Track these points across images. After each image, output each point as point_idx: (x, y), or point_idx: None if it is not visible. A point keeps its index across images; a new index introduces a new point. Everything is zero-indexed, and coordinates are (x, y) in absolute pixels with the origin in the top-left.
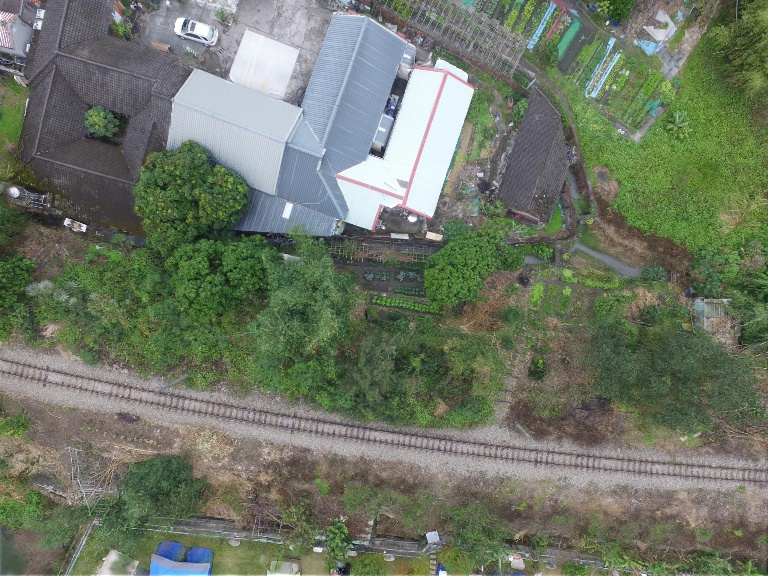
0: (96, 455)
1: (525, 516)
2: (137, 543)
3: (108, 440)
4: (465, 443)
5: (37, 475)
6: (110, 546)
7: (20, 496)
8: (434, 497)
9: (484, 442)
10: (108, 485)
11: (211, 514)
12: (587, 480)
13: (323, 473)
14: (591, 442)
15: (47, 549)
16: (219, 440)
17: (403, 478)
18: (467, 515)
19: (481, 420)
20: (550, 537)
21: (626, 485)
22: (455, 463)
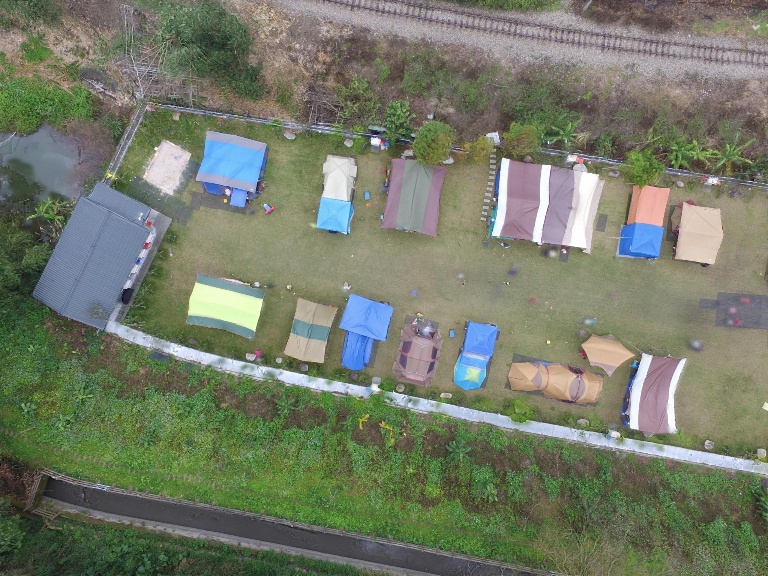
0: (150, 33)
1: (590, 107)
2: (190, 134)
3: (163, 11)
4: (530, 25)
5: (87, 69)
6: (162, 136)
7: (70, 85)
8: (497, 85)
9: (550, 25)
10: (162, 63)
11: (265, 116)
12: (655, 67)
13: (384, 52)
14: (661, 25)
15: (98, 132)
16: (277, 13)
17: (466, 62)
18: (531, 104)
19: (547, 1)
20: (613, 145)
21: (696, 73)
22: (519, 47)
